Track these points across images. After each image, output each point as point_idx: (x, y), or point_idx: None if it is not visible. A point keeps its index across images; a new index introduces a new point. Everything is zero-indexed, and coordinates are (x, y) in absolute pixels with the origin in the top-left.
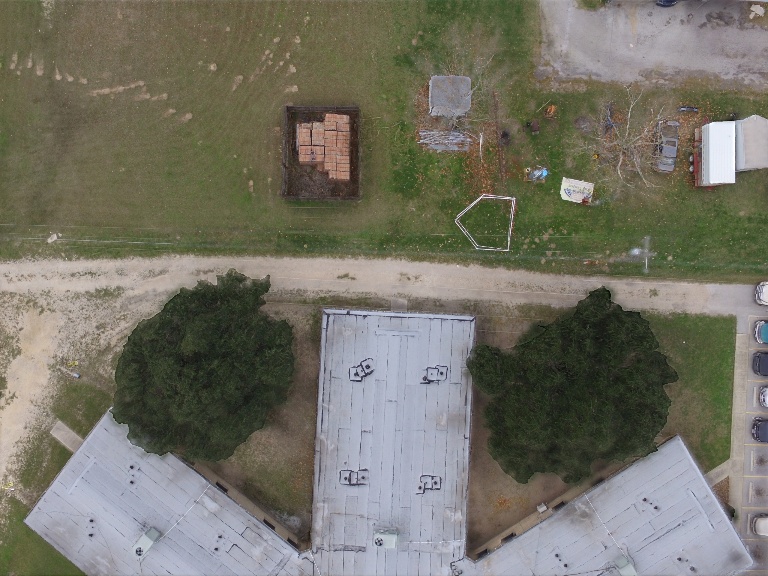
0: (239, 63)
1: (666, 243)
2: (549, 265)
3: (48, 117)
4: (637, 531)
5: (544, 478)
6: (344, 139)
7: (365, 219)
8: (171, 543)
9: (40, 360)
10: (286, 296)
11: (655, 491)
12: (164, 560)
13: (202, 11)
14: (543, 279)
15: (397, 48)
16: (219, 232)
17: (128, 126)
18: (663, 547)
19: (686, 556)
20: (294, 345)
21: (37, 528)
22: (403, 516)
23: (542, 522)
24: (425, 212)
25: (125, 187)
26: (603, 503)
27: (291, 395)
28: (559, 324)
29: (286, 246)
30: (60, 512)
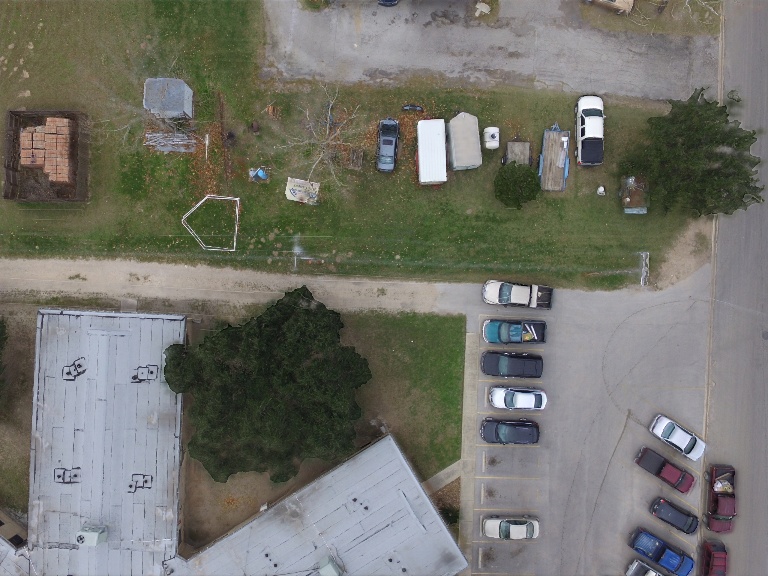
0: None
1: (393, 242)
2: (275, 265)
3: None
4: (347, 531)
5: None
6: (64, 142)
7: (94, 220)
8: None
9: None
10: (20, 297)
11: (366, 491)
12: None
13: None
14: (270, 279)
15: (126, 52)
16: None
17: None
18: (373, 548)
19: (398, 557)
20: (27, 345)
21: None
22: (114, 514)
23: (252, 522)
24: (153, 213)
25: None
26: (314, 503)
27: (24, 394)
28: (248, 323)
29: (19, 248)
30: None
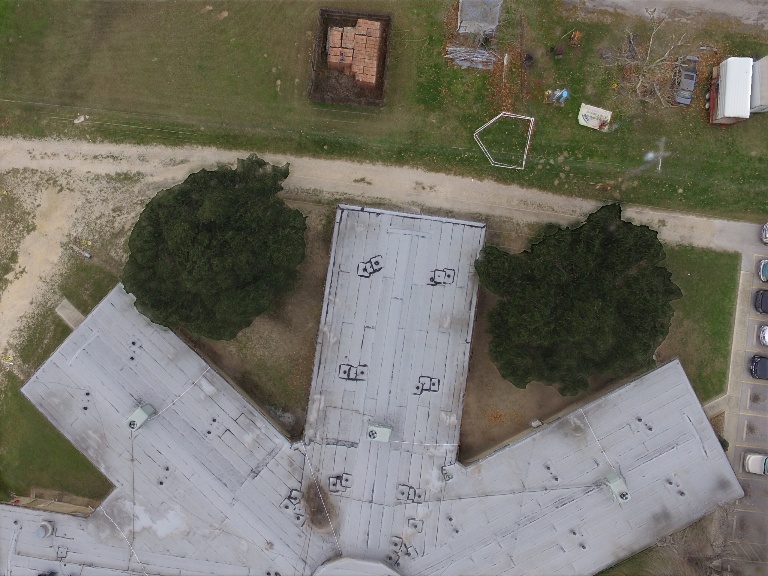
0: None
1: (678, 176)
2: (562, 187)
3: (88, 4)
4: (630, 451)
5: (541, 397)
6: (373, 44)
7: (386, 126)
8: (165, 422)
9: (54, 237)
10: (302, 195)
11: (651, 413)
12: (156, 439)
13: None
14: (555, 200)
15: None
16: (242, 127)
17: (165, 18)
18: (655, 469)
19: (678, 481)
20: None
21: (33, 397)
22: (399, 415)
23: (536, 433)
24: (445, 125)
25: (155, 76)
26: (599, 420)
27: (297, 292)
28: None
29: (306, 146)
30: (58, 383)
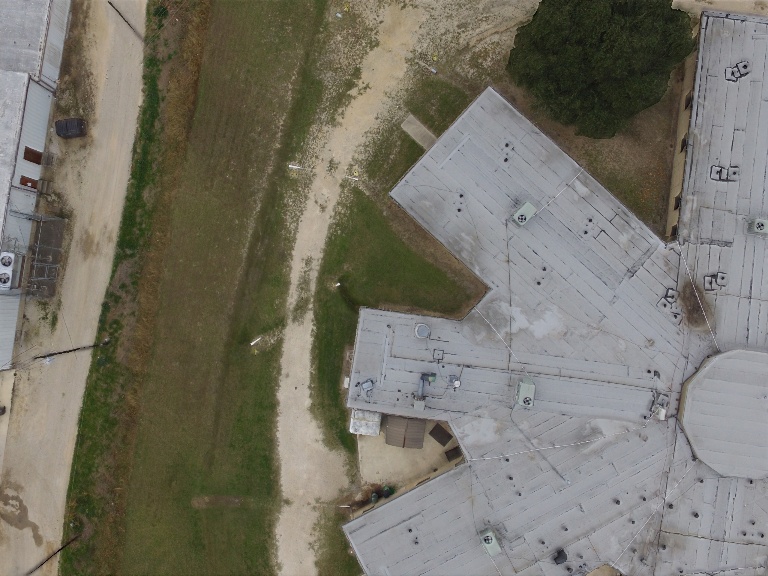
0: None
1: None
2: None
3: None
4: None
5: None
6: None
7: None
8: (542, 222)
9: (398, 53)
10: None
11: None
12: (533, 239)
13: None
14: None
15: None
16: None
17: None
18: None
19: None
20: None
21: (403, 201)
22: None
23: None
24: None
25: None
26: None
27: None
28: None
29: None
30: (428, 186)
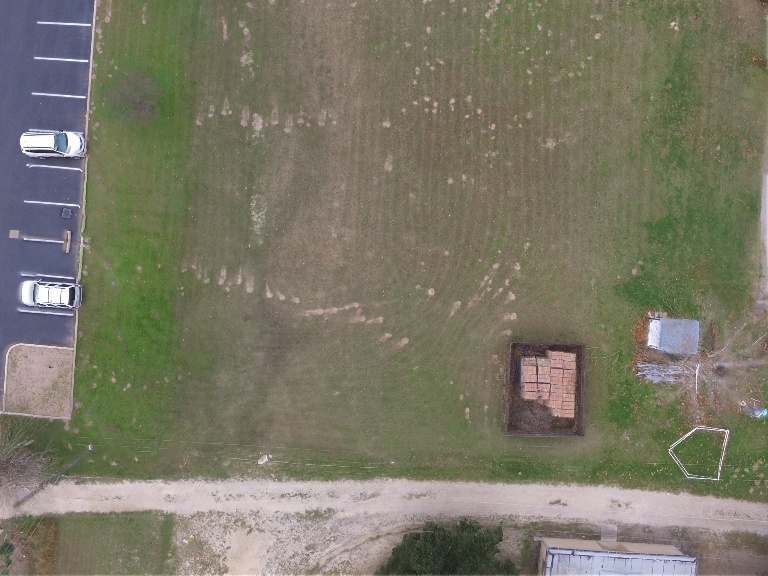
0: (457, 288)
1: None
2: (757, 494)
3: (258, 336)
4: None
5: None
6: (570, 377)
7: (580, 448)
8: None
9: None
10: (498, 521)
11: None
12: None
13: (420, 234)
14: (750, 507)
15: (617, 277)
16: (433, 458)
17: (342, 349)
18: None
19: None
20: None
21: None
22: None
23: None
24: (639, 441)
25: (339, 411)
26: None
27: None
28: None
29: (500, 473)
30: None
